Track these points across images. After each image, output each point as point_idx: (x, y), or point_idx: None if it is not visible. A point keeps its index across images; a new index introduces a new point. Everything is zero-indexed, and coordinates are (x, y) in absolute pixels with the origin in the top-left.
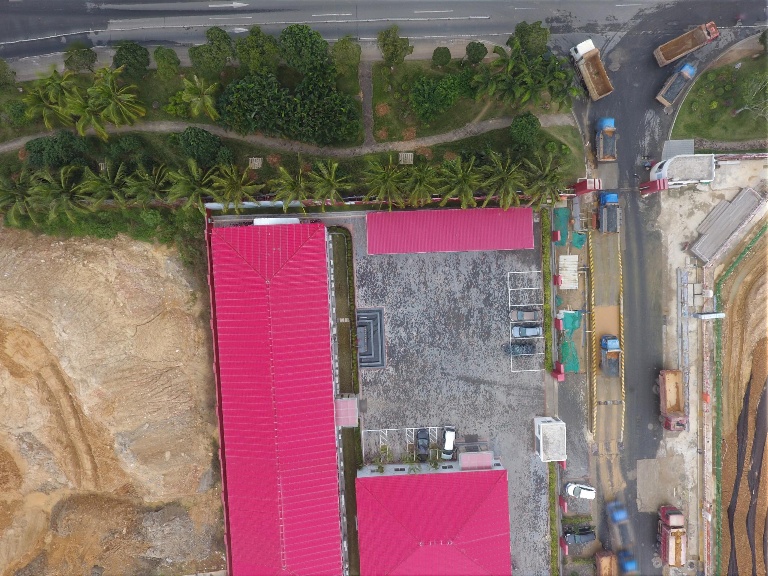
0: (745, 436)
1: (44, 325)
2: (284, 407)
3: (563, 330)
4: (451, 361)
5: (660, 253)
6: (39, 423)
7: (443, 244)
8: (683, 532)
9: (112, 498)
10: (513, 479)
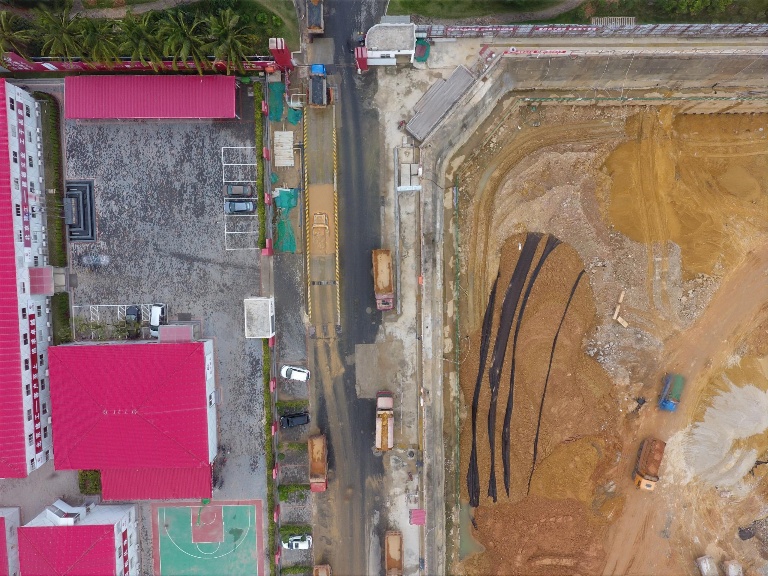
0: (489, 333)
1: None
2: None
3: (279, 209)
4: (164, 237)
5: (377, 132)
6: None
7: (142, 110)
8: (391, 415)
9: None
10: (228, 360)
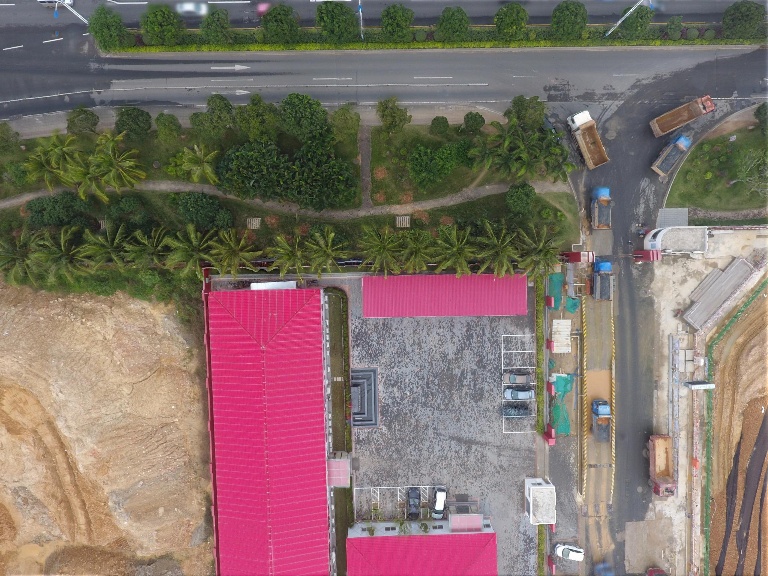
0: (734, 496)
1: (41, 385)
2: (277, 470)
3: (555, 393)
4: (443, 421)
5: (653, 319)
6: (34, 479)
7: (438, 309)
8: None
9: (105, 551)
10: (503, 539)
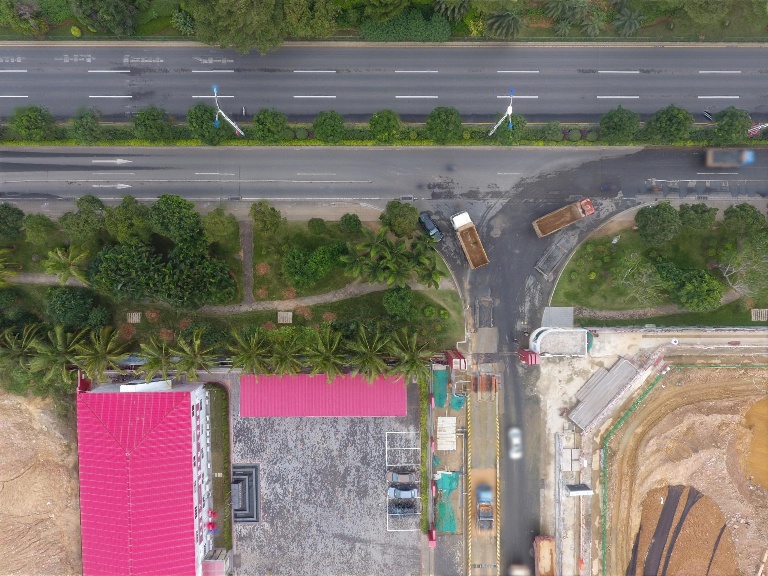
0: None
1: None
2: None
3: (440, 490)
4: (327, 518)
5: (539, 417)
6: None
7: (316, 409)
8: None
9: None
10: None
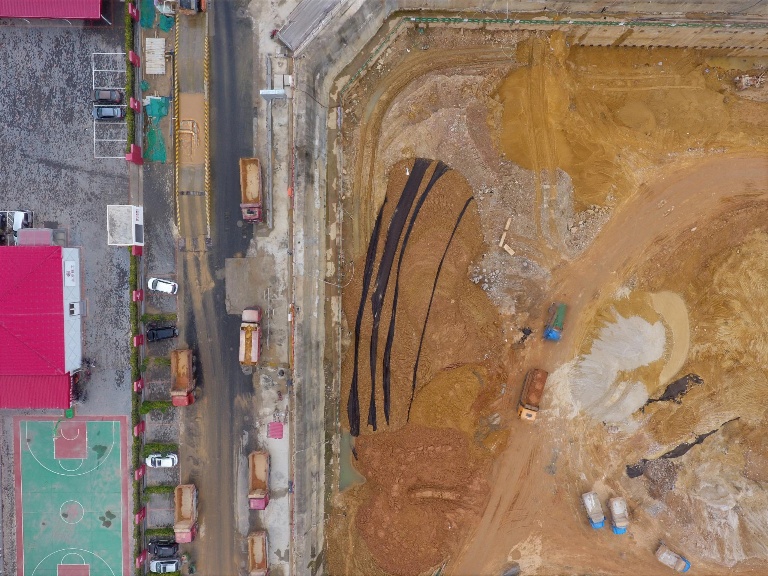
0: (373, 258)
1: None
2: None
3: (150, 117)
4: (31, 143)
5: (251, 41)
6: None
7: (6, 8)
8: (255, 328)
9: None
10: (95, 271)
